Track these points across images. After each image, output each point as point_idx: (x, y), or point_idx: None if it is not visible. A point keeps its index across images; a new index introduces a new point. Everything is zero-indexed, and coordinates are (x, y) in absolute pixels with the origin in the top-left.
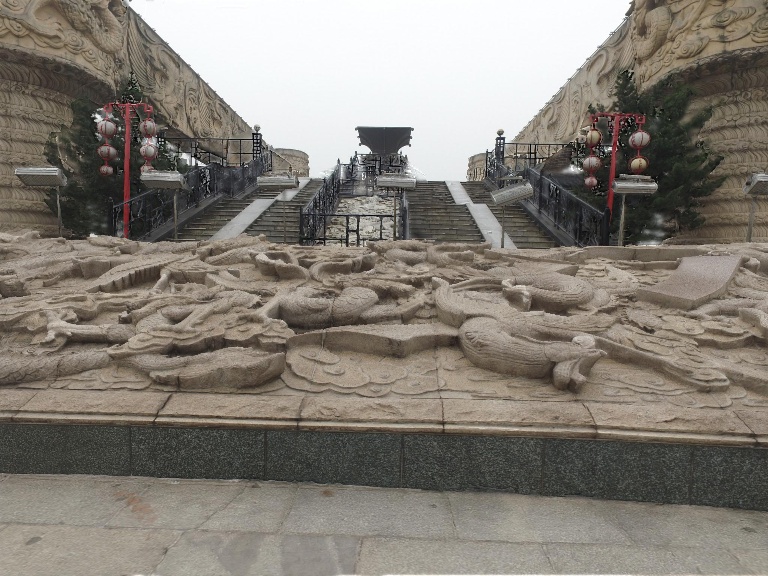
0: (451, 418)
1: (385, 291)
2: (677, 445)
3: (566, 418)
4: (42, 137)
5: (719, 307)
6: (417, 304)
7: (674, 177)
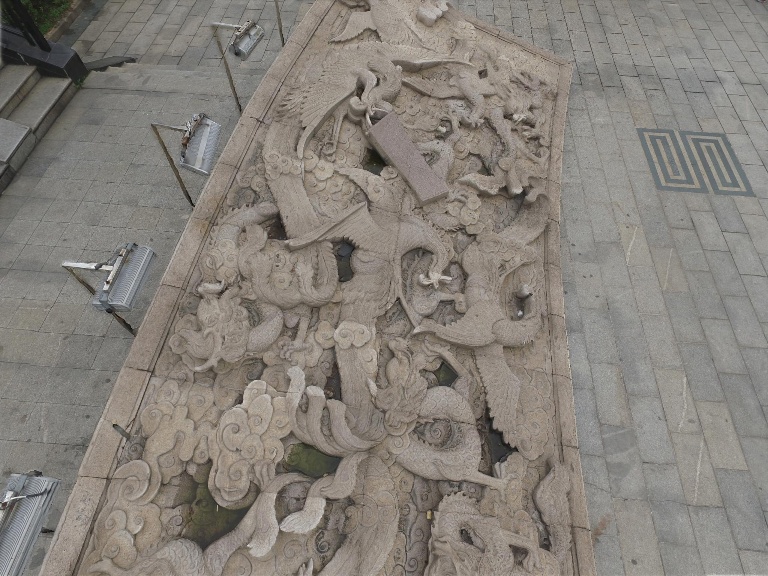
0: None
1: None
2: None
3: None
4: None
5: None
6: None
7: None
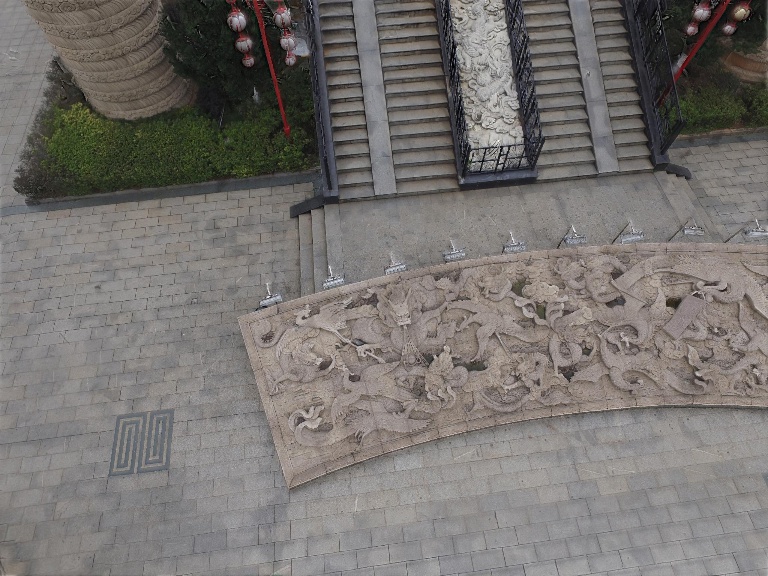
0: None
1: None
2: None
3: None
4: None
5: None
6: None
7: (764, 27)
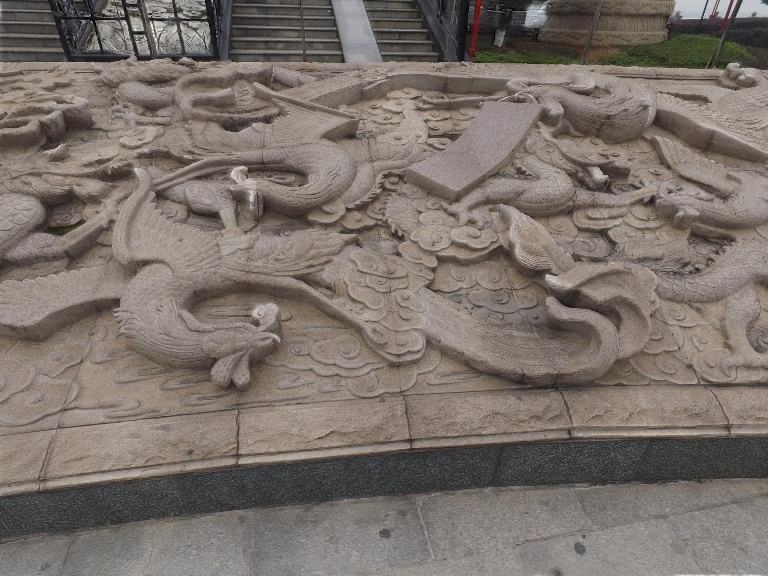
0: (50, 474)
1: (64, 195)
2: (328, 461)
3: (200, 453)
4: None
5: (487, 195)
6: (96, 227)
7: None
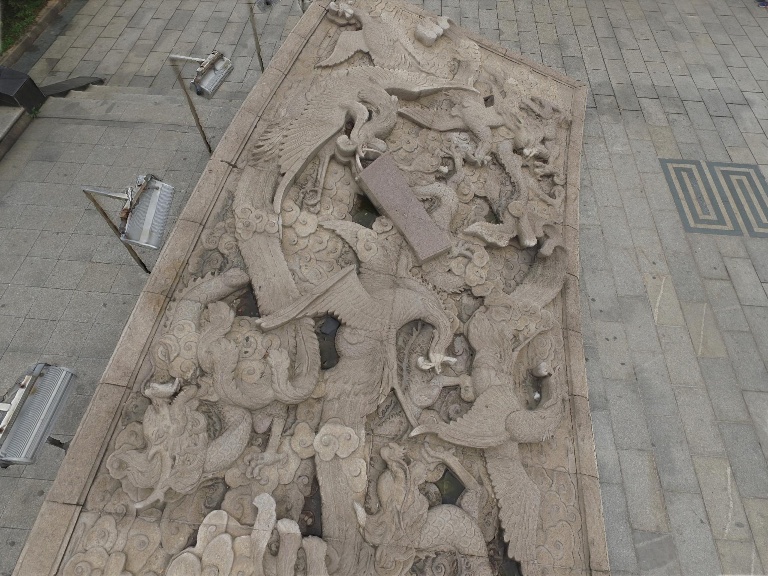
0: None
1: None
2: None
3: None
4: None
5: None
6: None
7: None
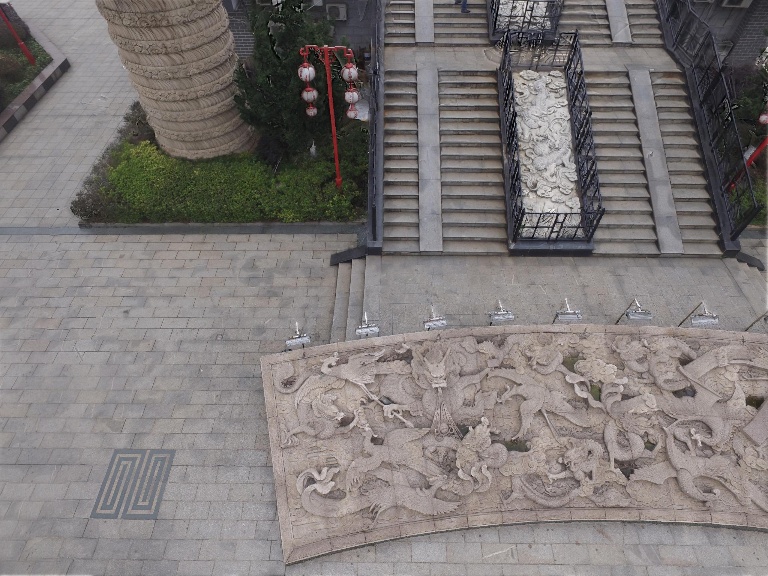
0: (678, 520)
1: None
2: None
3: None
4: (204, 37)
5: None
6: None
7: None
